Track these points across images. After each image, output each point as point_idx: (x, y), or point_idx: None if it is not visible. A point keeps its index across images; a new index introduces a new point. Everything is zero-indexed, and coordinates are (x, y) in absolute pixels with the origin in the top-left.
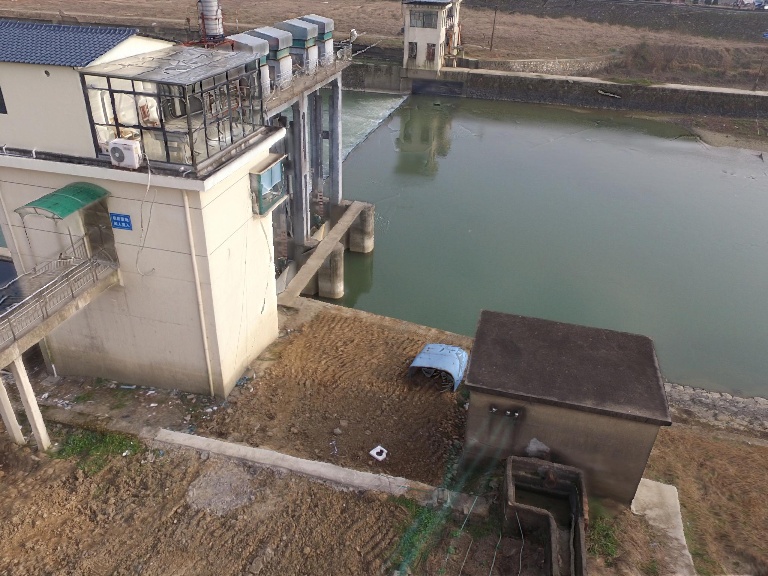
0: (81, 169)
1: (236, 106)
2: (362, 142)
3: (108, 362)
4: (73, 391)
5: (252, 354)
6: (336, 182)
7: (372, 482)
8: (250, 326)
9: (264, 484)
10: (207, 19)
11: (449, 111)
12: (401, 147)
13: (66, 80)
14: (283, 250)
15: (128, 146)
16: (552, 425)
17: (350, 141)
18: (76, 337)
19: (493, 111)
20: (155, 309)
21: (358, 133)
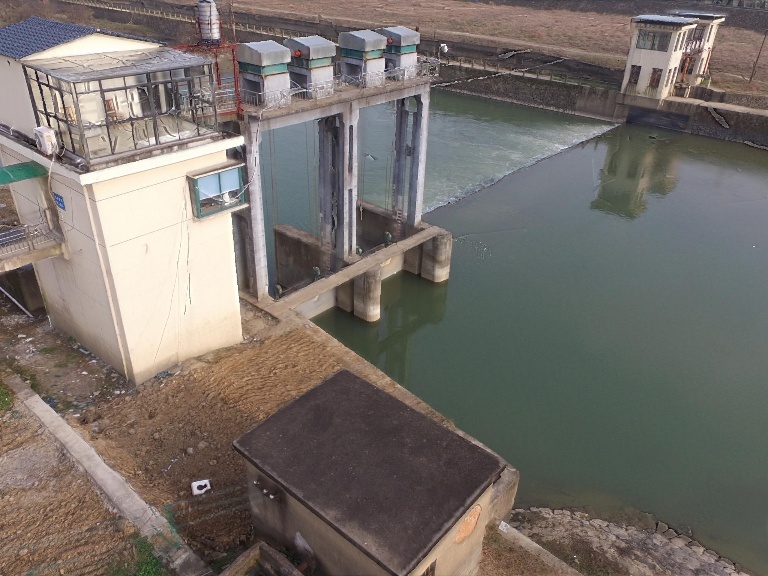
0: (23, 149)
1: (235, 110)
2: (526, 167)
3: (74, 325)
4: (48, 342)
5: (190, 352)
6: (414, 202)
7: (136, 512)
8: (186, 324)
9: (58, 475)
10: (202, 23)
11: (658, 146)
12: (603, 179)
13: (17, 70)
14: (327, 260)
15: (41, 133)
16: (309, 524)
17: (515, 164)
18: (56, 296)
19: (715, 153)
20: (88, 286)
21: (533, 157)
